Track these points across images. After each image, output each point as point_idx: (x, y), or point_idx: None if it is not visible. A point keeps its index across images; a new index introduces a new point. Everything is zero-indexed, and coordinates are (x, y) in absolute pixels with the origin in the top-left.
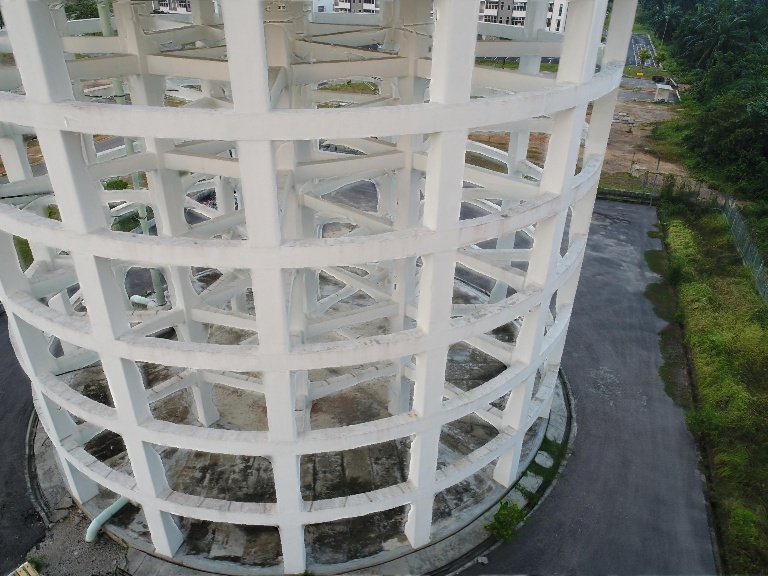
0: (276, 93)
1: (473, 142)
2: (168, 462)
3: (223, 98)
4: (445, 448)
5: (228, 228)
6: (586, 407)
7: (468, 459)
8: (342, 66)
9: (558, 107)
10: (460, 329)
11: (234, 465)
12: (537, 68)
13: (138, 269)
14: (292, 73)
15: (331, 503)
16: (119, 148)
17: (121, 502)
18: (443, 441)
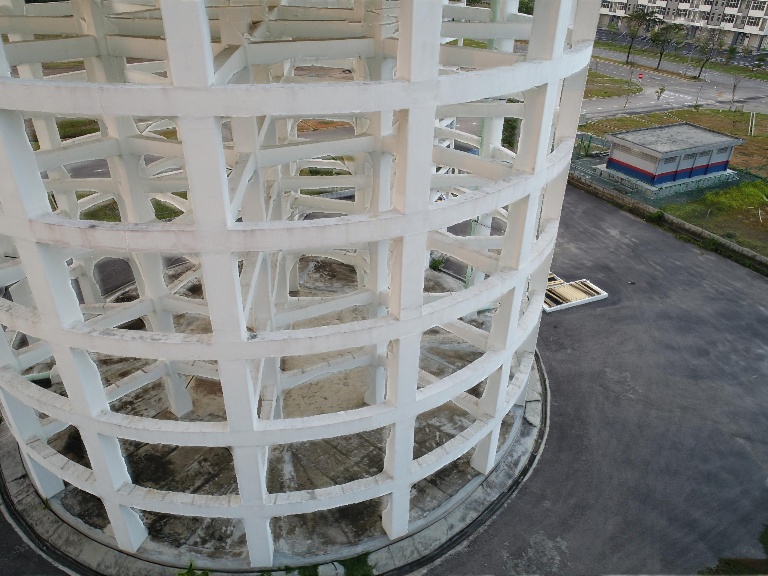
0: (12, 54)
1: None
2: (103, 367)
3: (276, 77)
4: None
5: (176, 190)
6: (466, 564)
7: (165, 494)
8: (155, 43)
9: (131, 110)
10: (76, 335)
11: (127, 395)
12: (578, 95)
13: None
14: (106, 43)
15: (44, 449)
16: None
17: (44, 375)
18: (269, 484)
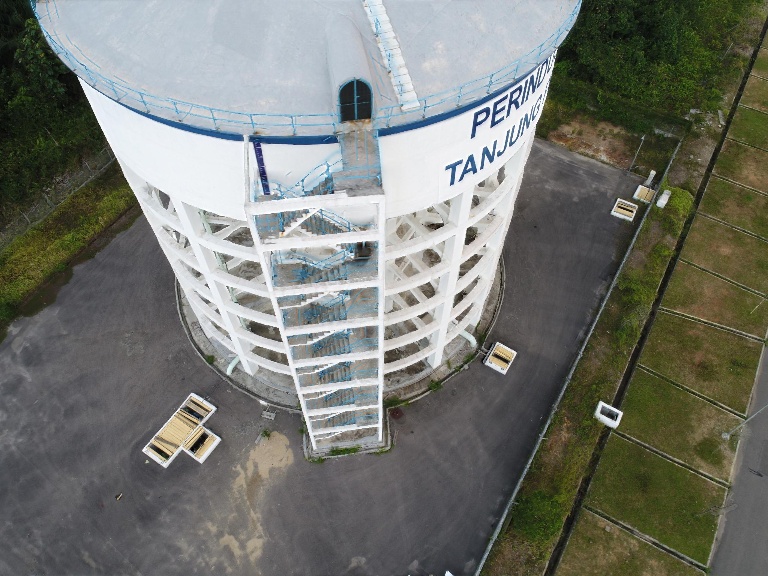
0: None
1: None
2: None
3: None
4: None
5: None
6: None
7: None
8: None
9: None
10: None
11: None
12: None
13: (487, 412)
14: None
15: None
16: (476, 265)
17: None
18: None
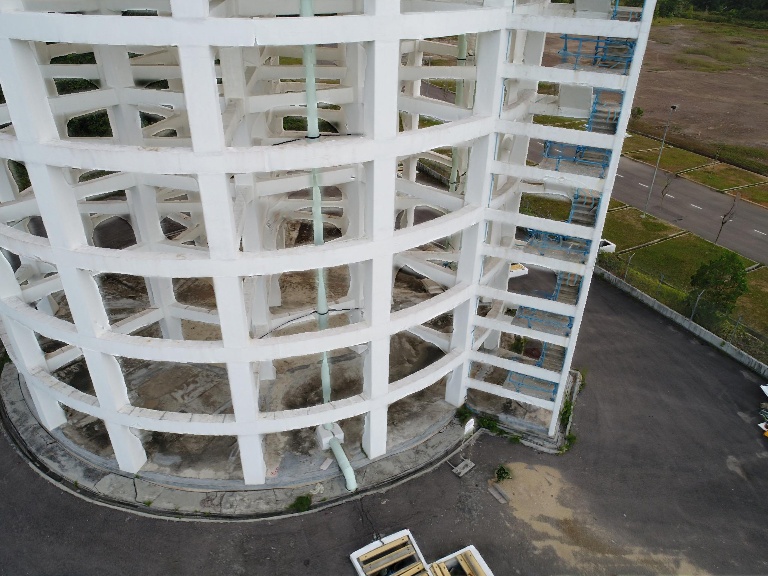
0: None
1: (180, 256)
2: None
3: None
4: (105, 307)
5: None
6: None
7: None
8: None
9: None
10: None
11: None
12: (6, 84)
13: None
14: None
15: None
16: None
17: None
18: (110, 309)
